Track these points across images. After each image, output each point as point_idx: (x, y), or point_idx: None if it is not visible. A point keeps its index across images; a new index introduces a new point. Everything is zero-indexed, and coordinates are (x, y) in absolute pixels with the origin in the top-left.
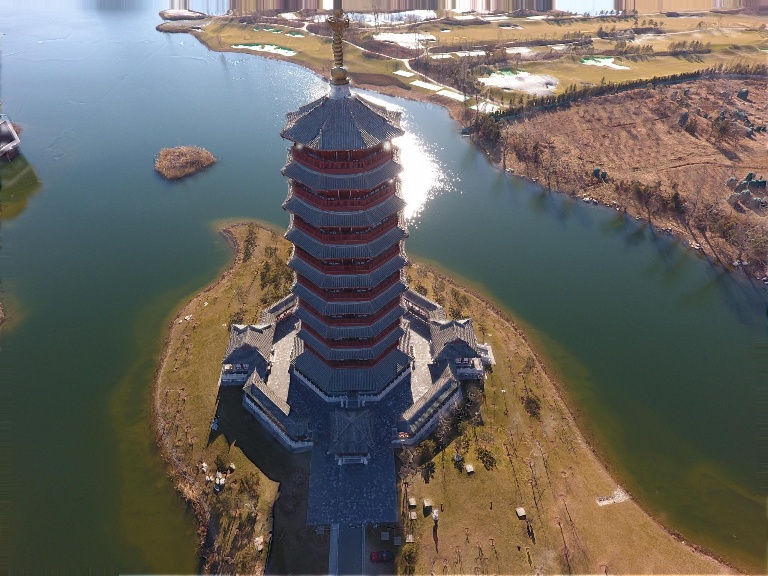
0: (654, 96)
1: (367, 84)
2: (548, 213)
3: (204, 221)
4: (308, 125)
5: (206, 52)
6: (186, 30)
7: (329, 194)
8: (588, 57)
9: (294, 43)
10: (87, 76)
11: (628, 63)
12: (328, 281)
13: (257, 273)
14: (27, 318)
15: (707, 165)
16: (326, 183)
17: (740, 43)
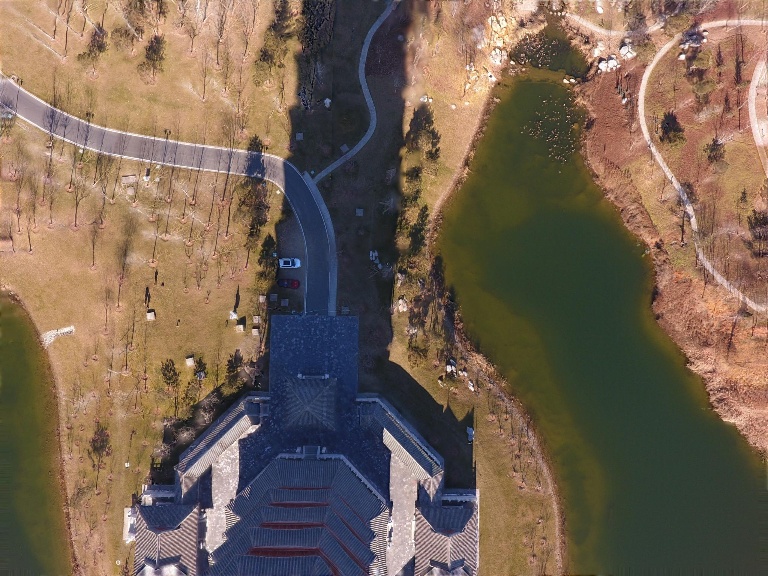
0: None
1: None
2: None
3: None
4: None
5: None
6: None
7: None
8: None
9: None
10: None
11: None
12: (307, 570)
13: None
14: None
15: None
16: None
17: None
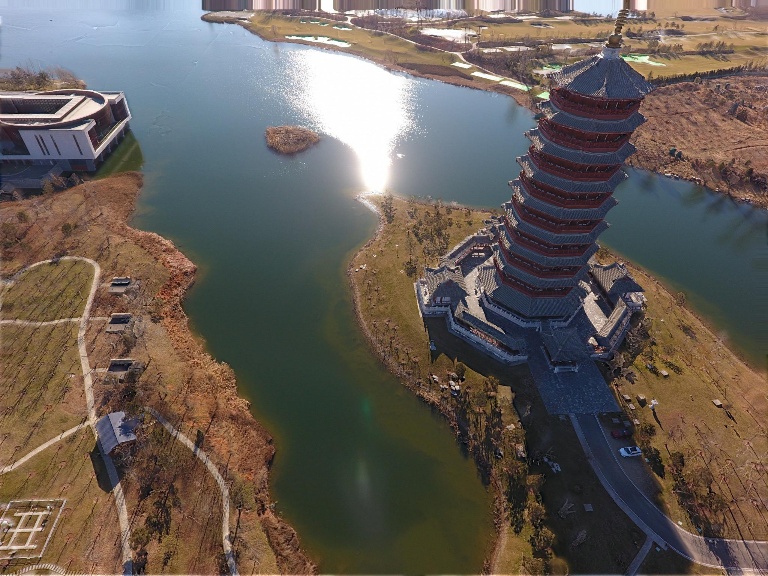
0: (700, 89)
1: (430, 74)
2: (639, 186)
3: (334, 190)
4: (587, 80)
5: (260, 42)
6: (233, 21)
7: (590, 138)
8: (626, 54)
9: (344, 35)
10: (157, 61)
11: (663, 60)
12: (565, 214)
13: (408, 231)
14: (212, 268)
15: (766, 147)
16: (597, 127)
17: (757, 45)
